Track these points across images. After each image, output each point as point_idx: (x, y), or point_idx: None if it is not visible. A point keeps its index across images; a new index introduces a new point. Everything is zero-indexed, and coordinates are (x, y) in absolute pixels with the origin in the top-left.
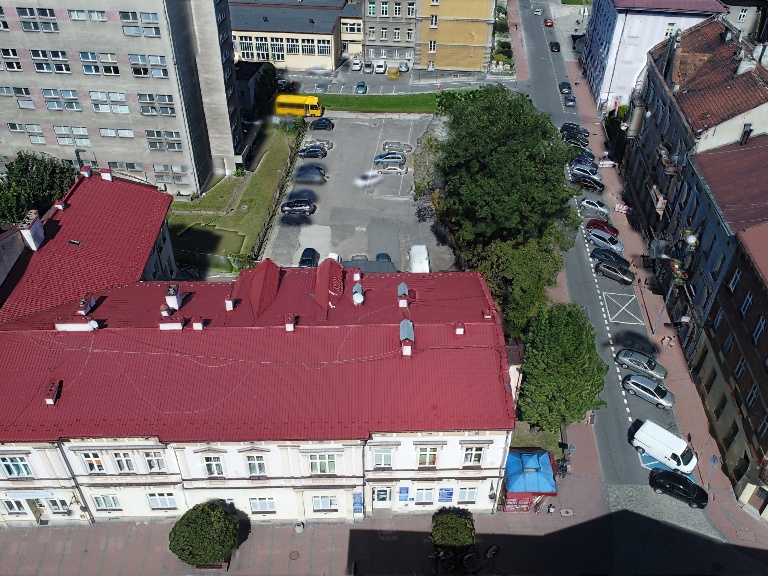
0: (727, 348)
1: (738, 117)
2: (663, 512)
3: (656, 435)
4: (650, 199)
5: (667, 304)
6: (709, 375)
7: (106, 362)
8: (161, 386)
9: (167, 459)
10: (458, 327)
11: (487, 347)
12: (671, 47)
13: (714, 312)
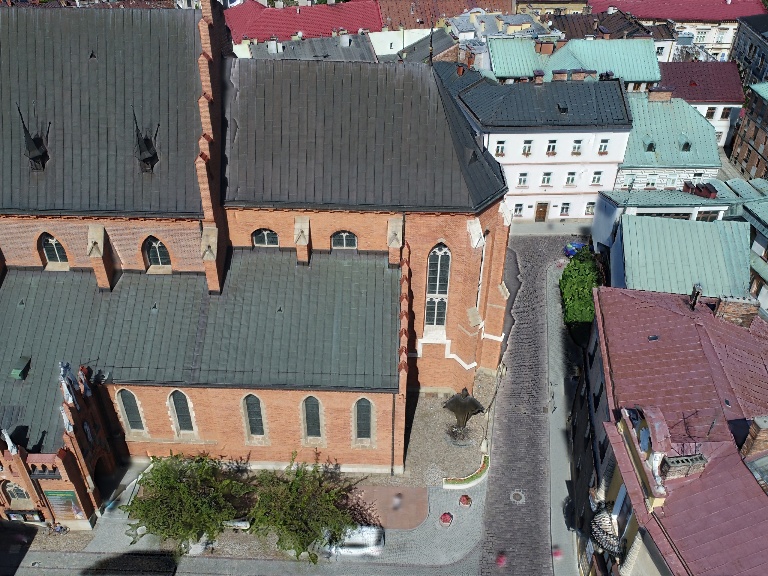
0: None
1: None
2: None
3: None
4: None
5: None
6: None
7: (627, 3)
8: (649, 8)
9: None
10: None
11: (756, 3)
12: None
13: None
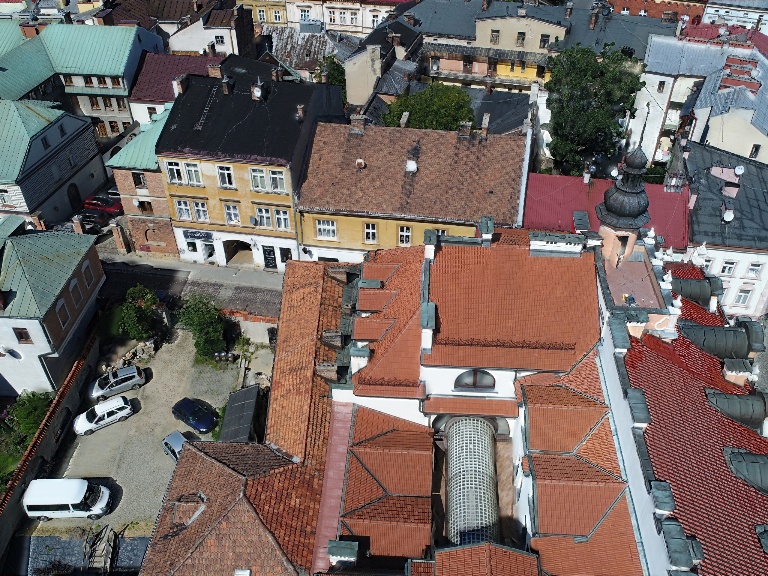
0: None
1: None
2: None
3: None
4: None
5: None
6: None
7: None
8: None
9: (359, 17)
10: None
11: None
12: None
13: None
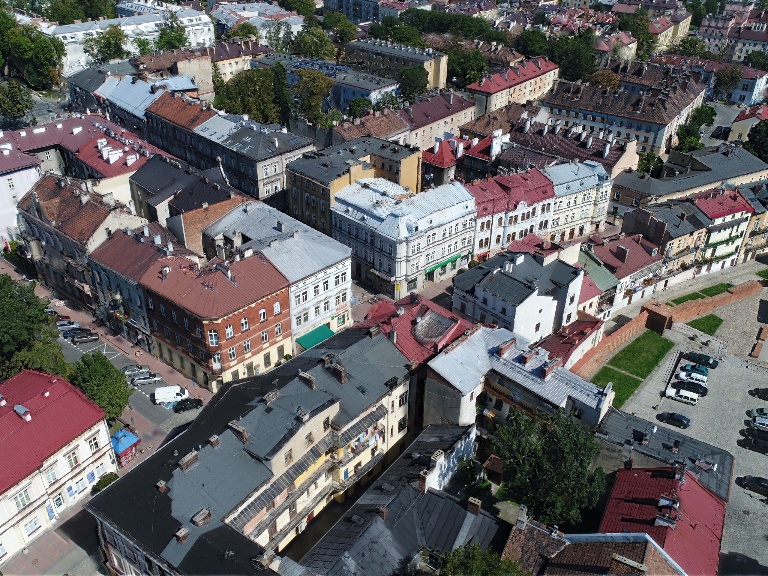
0: (168, 335)
1: (100, 227)
2: (189, 418)
3: (164, 391)
4: (76, 289)
5: (125, 337)
6: (168, 354)
7: None
8: None
9: None
10: (46, 392)
11: (66, 393)
12: (35, 202)
13: (151, 324)
